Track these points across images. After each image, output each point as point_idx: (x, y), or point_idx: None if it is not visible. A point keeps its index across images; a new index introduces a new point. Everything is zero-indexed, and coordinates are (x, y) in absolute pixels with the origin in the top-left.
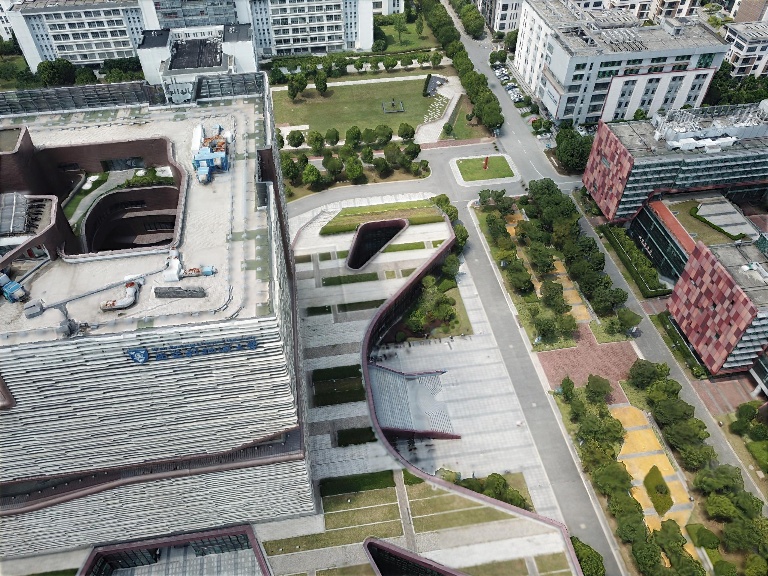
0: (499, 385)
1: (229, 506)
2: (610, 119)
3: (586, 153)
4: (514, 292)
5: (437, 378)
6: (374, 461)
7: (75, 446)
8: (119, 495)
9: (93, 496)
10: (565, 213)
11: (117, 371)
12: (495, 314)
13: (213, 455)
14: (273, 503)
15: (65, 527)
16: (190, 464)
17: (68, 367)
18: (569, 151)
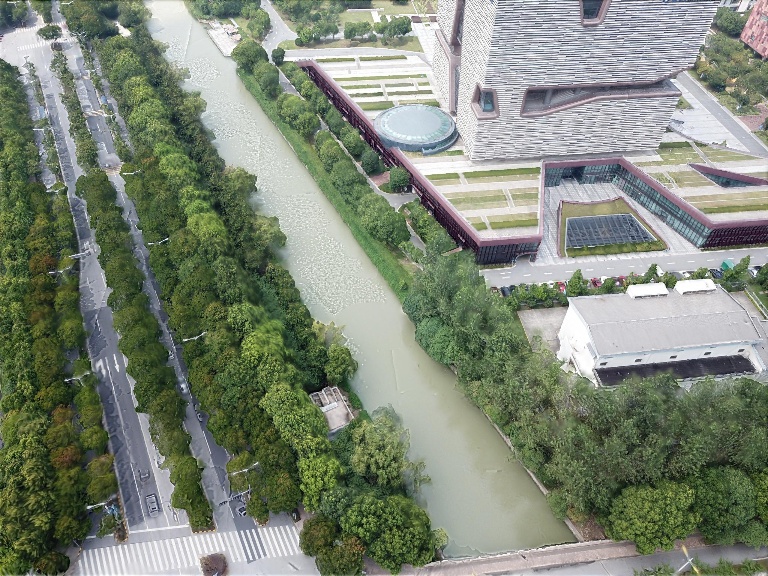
0: (719, 129)
1: (626, 133)
2: (744, 10)
3: (739, 22)
4: (712, 91)
5: (681, 125)
6: (676, 139)
7: (600, 62)
8: (587, 111)
9: (578, 108)
10: (738, 49)
11: (652, 7)
12: (703, 100)
13: (647, 82)
14: (646, 135)
15: (548, 134)
16: (628, 93)
17: (636, 1)
18: (729, 19)
